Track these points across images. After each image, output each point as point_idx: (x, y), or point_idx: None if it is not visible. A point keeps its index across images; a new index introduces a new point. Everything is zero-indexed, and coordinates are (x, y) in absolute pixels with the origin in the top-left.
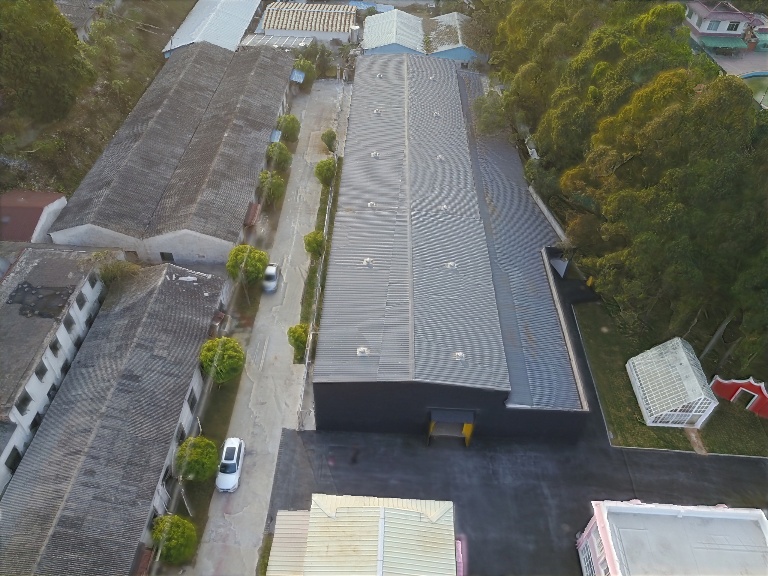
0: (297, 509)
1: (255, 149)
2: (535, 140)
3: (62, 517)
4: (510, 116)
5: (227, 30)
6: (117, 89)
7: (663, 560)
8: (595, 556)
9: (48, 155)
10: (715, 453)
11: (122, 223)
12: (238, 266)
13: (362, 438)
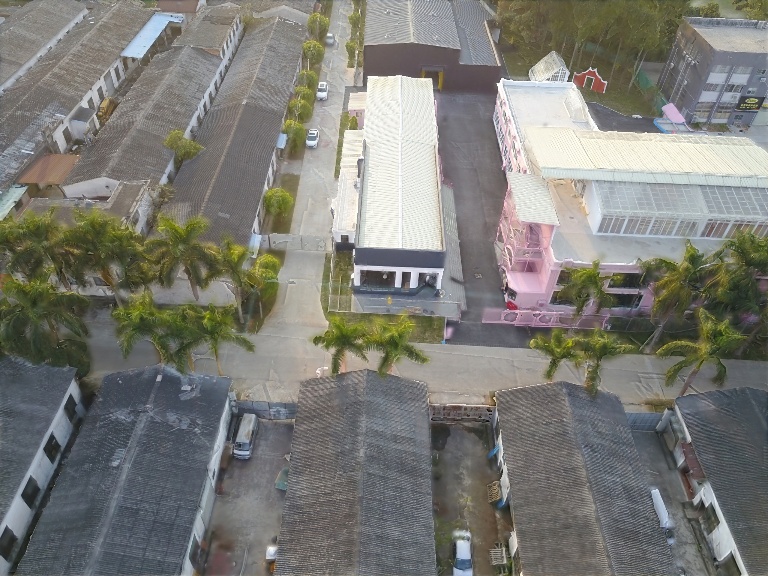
0: None
1: None
2: None
3: (257, 77)
4: None
5: None
6: None
7: (526, 95)
8: None
9: None
10: None
11: None
12: (315, 22)
13: None
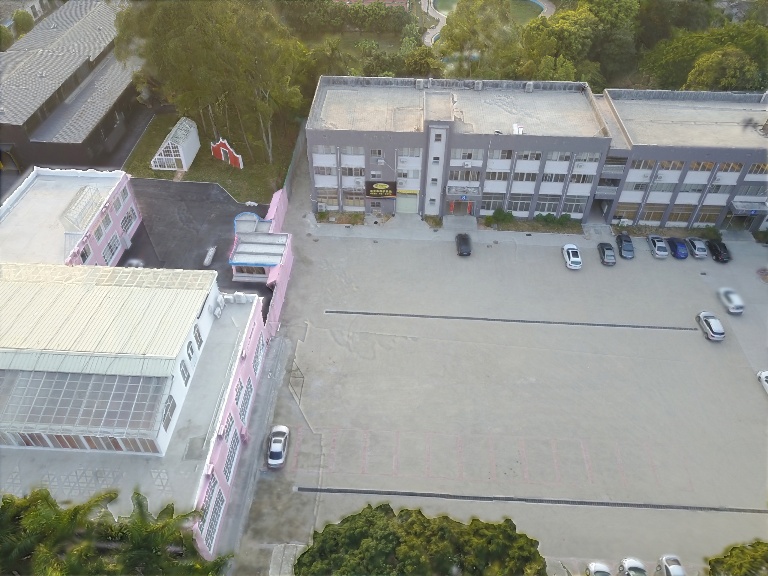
0: None
1: None
2: None
3: None
4: None
5: None
6: None
7: (50, 190)
8: None
9: None
10: (184, 181)
11: None
12: None
13: None
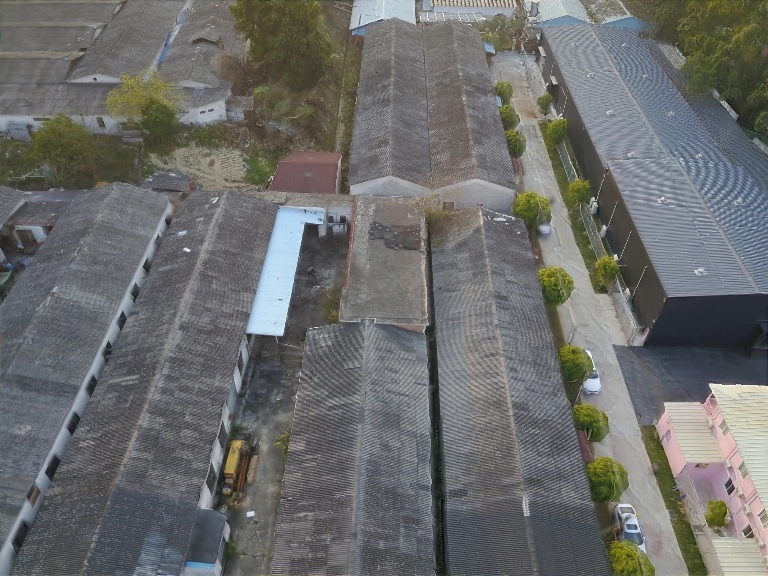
0: (659, 407)
1: (491, 111)
2: (767, 94)
3: (513, 402)
4: (721, 76)
5: (401, 8)
6: (334, 63)
7: None
8: None
9: (304, 121)
10: None
11: (413, 175)
12: (531, 210)
13: (687, 351)
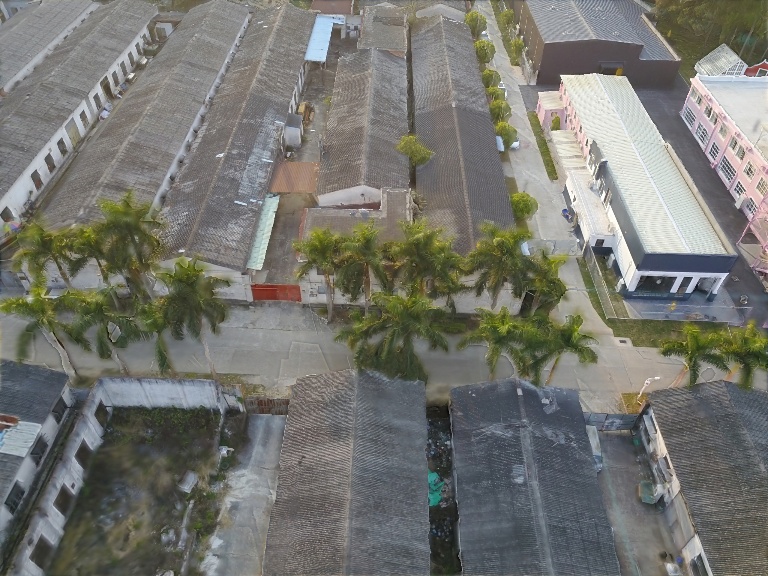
0: None
1: None
2: None
3: (452, 78)
4: None
5: None
6: None
7: (726, 90)
8: (692, 103)
9: None
10: None
11: (400, 4)
12: (474, 20)
13: None
